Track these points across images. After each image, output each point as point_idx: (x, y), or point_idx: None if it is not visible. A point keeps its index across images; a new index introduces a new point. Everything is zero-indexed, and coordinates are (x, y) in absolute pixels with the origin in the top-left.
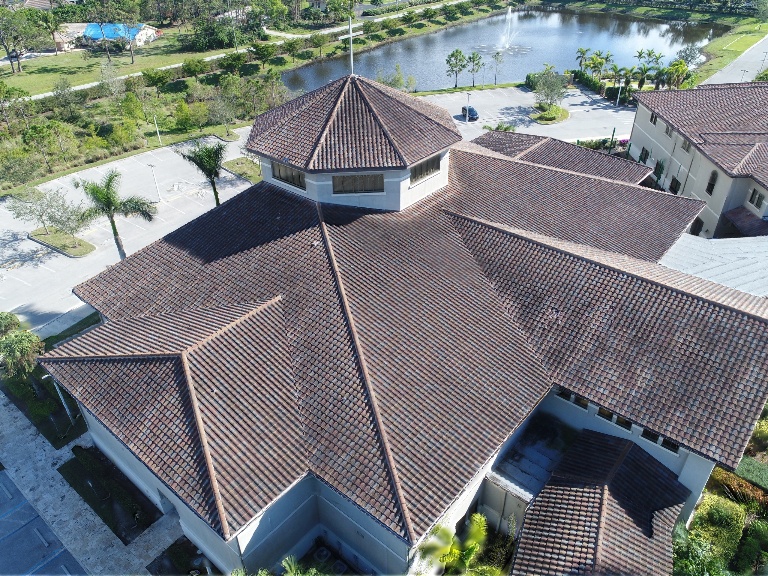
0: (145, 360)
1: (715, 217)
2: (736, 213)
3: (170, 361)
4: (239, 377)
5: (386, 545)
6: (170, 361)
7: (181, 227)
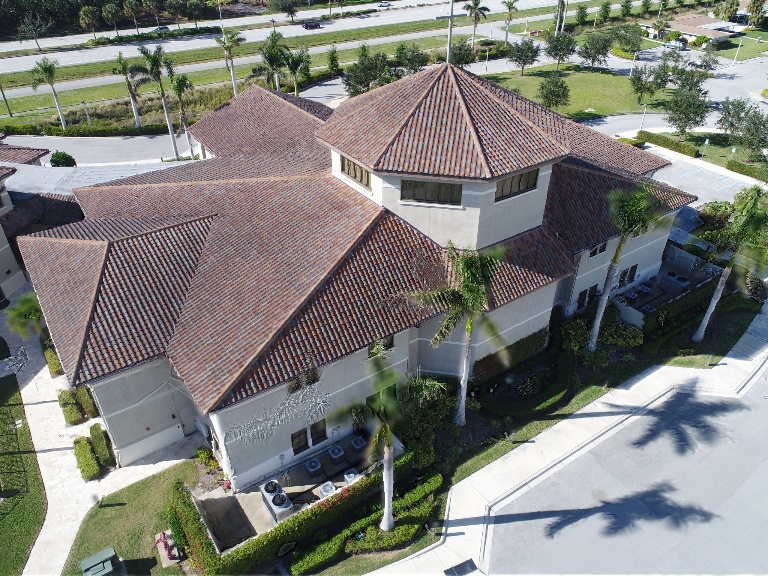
0: None
1: (5, 250)
2: (5, 227)
3: None
4: None
5: None
6: None
7: (618, 176)
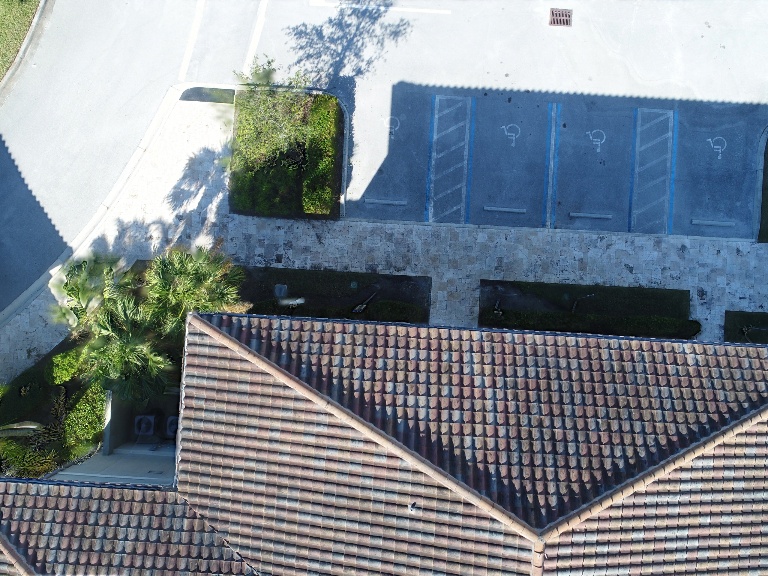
0: (614, 480)
1: None
2: None
3: (553, 509)
4: (402, 568)
5: (95, 477)
6: (553, 509)
7: None
